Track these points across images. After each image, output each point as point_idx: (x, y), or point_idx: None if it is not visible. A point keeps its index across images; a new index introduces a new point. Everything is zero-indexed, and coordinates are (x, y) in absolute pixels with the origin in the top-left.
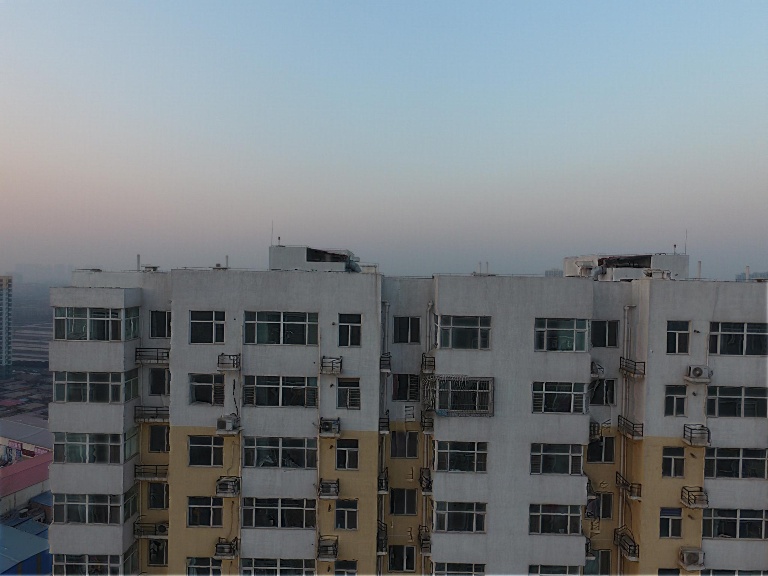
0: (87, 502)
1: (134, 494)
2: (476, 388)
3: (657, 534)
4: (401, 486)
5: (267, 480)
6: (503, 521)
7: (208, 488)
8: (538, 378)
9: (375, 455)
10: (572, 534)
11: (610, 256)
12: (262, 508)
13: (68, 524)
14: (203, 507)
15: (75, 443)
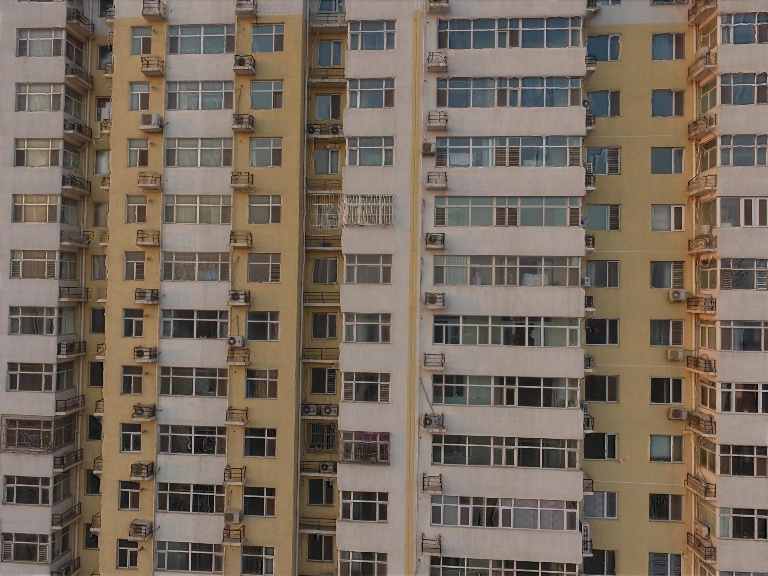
0: None
1: None
2: None
3: (126, 106)
4: None
5: None
6: None
7: None
8: None
9: None
10: (54, 111)
11: None
12: None
13: None
14: None
15: None
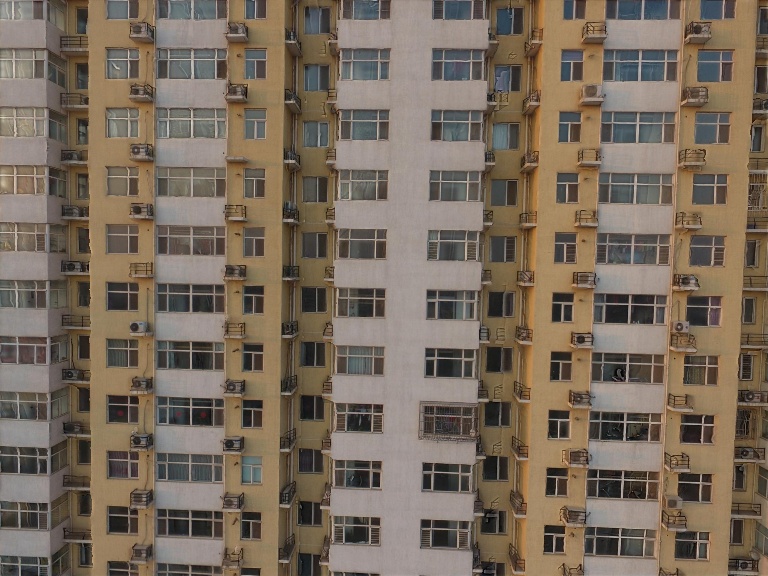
0: (14, 58)
1: (61, 68)
2: None
3: (558, 76)
4: (314, 61)
5: (180, 30)
6: (406, 66)
7: (124, 39)
8: None
9: (282, 3)
10: (474, 80)
11: None
12: (176, 60)
13: None
14: (121, 60)
15: (2, 1)
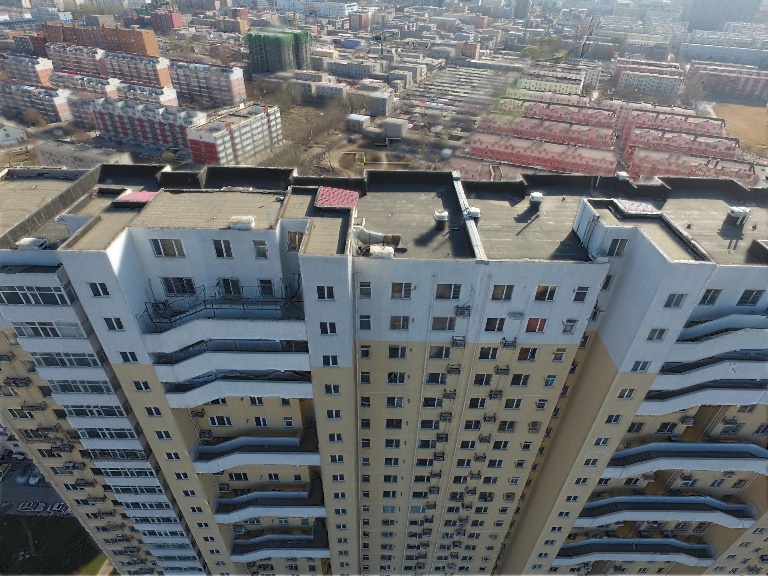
0: None
1: None
2: None
3: None
4: None
5: None
6: None
7: None
8: None
9: None
10: None
11: (651, 213)
12: None
13: None
14: None
15: None
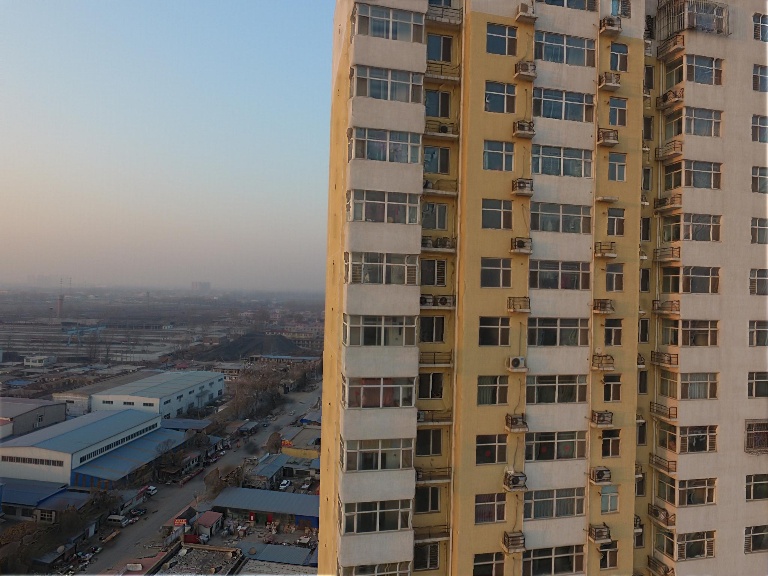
0: (389, 79)
1: None
2: (714, 14)
3: None
4: None
5: (555, 73)
6: (735, 127)
7: (505, 74)
8: (758, 10)
9: (641, 60)
10: None
11: None
12: (549, 100)
13: (372, 98)
14: (498, 94)
15: (378, 18)
